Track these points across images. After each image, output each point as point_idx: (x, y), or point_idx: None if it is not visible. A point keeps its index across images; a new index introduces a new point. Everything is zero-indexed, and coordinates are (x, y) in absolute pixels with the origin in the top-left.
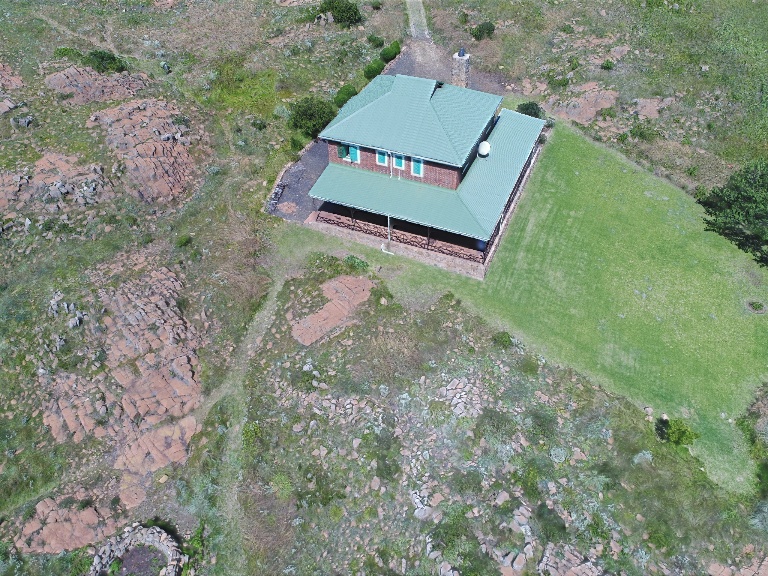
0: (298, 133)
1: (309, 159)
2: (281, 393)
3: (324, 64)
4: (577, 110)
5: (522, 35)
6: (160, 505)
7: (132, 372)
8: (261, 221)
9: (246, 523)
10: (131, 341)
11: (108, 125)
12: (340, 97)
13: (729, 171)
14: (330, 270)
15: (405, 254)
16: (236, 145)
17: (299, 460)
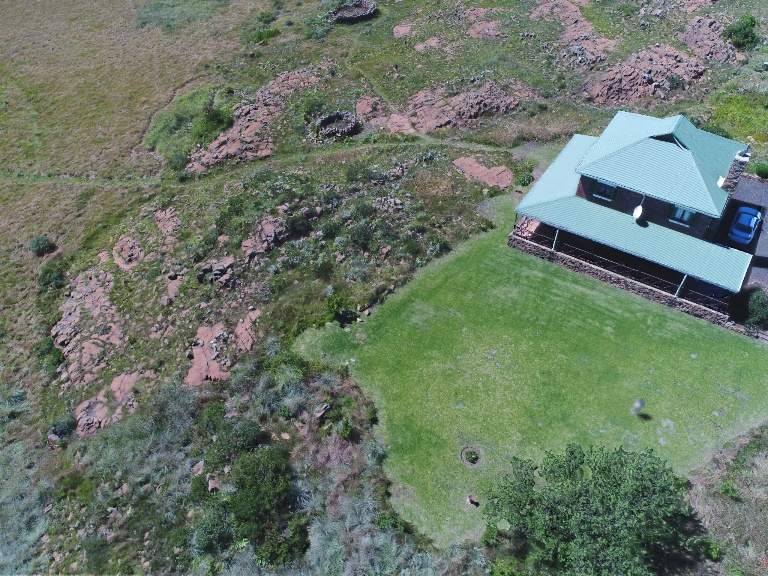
0: None
1: None
2: None
3: None
4: None
5: None
6: (369, 129)
7: None
8: None
9: None
10: None
11: None
12: (764, 165)
13: (750, 557)
14: None
15: None
16: None
17: None
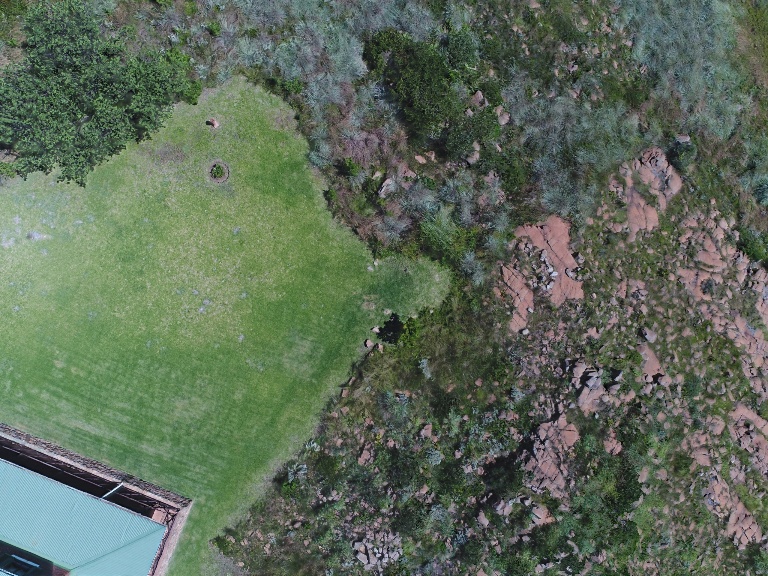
0: None
1: None
2: None
3: None
4: None
5: None
6: None
7: None
8: None
9: None
10: None
11: None
12: None
13: None
14: None
15: None
16: None
17: None
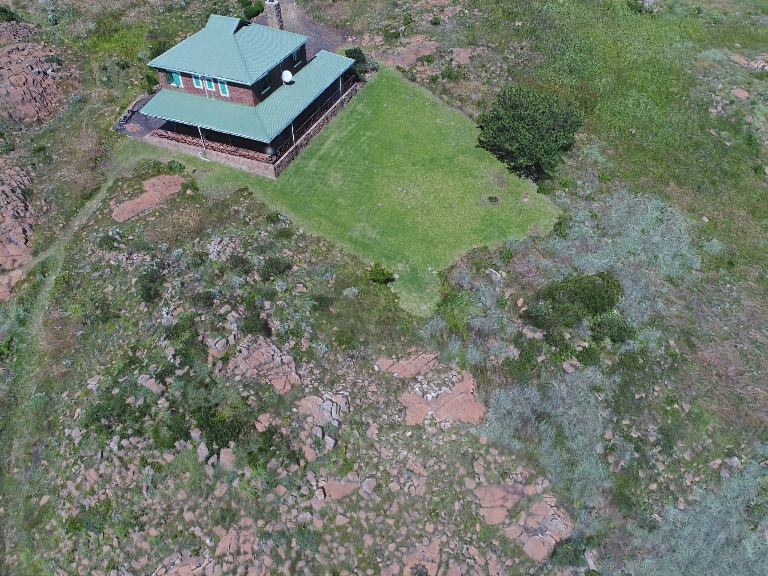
0: None
1: None
2: (91, 253)
3: (194, 20)
4: (400, 57)
5: None
6: None
7: None
8: (108, 137)
9: (44, 336)
10: None
11: None
12: None
13: None
14: (154, 171)
15: (218, 160)
16: (101, 81)
17: (93, 296)
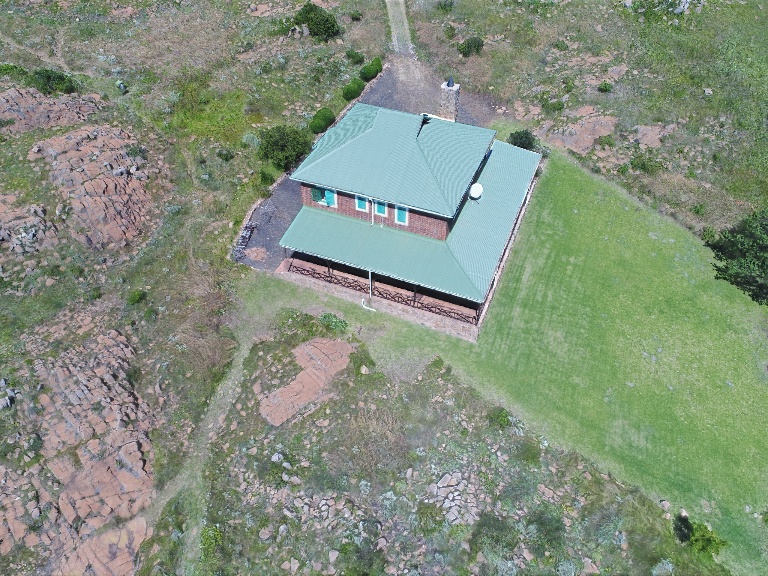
0: (269, 164)
1: (281, 195)
2: (246, 487)
3: (299, 83)
4: (574, 138)
5: (513, 52)
6: None
7: (72, 464)
8: (226, 270)
9: None
10: (71, 424)
11: (53, 158)
12: (316, 123)
13: (738, 209)
14: (304, 331)
15: (388, 311)
16: (200, 179)
17: (266, 574)
